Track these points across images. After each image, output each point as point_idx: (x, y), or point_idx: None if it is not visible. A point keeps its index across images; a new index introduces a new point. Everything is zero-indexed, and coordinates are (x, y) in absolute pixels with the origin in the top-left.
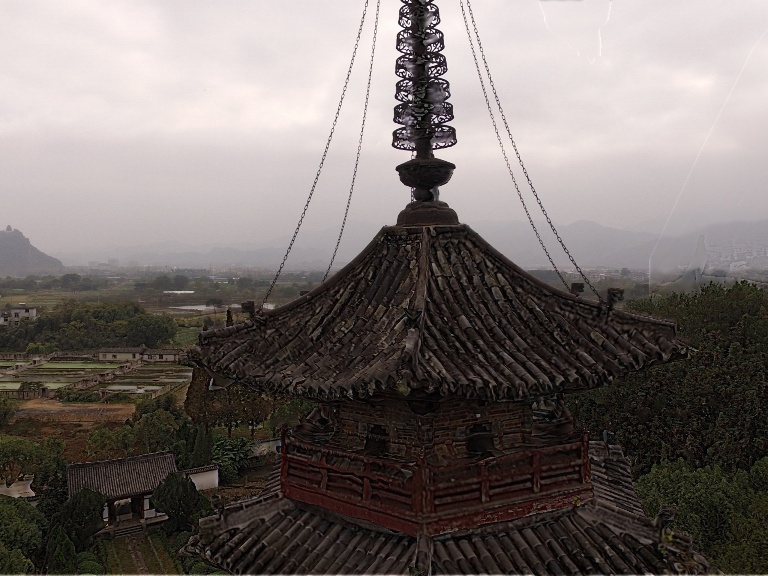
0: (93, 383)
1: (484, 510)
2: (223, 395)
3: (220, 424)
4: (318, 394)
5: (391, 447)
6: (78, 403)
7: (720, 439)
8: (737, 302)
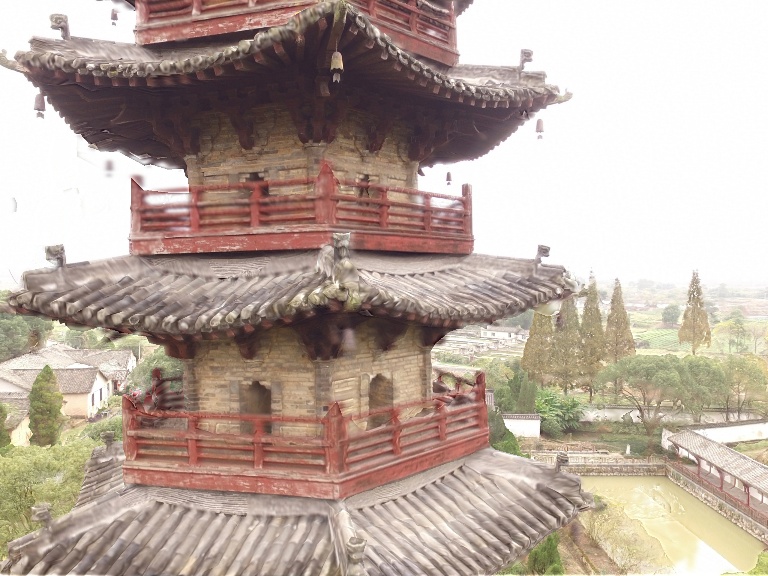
0: (469, 352)
1: (193, 22)
2: (561, 357)
3: (555, 384)
4: None
5: None
6: (451, 364)
7: None
8: None
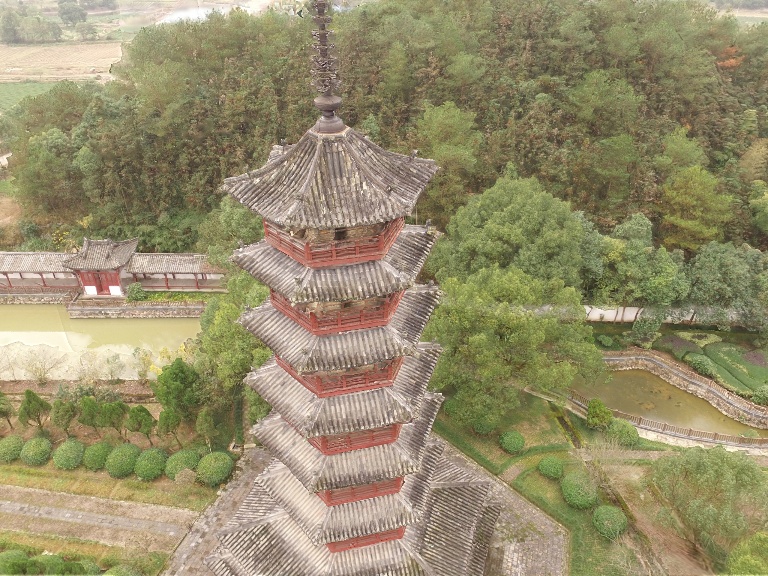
0: None
1: None
2: None
3: None
4: (365, 224)
5: (348, 232)
6: None
7: (260, 146)
8: (241, 30)
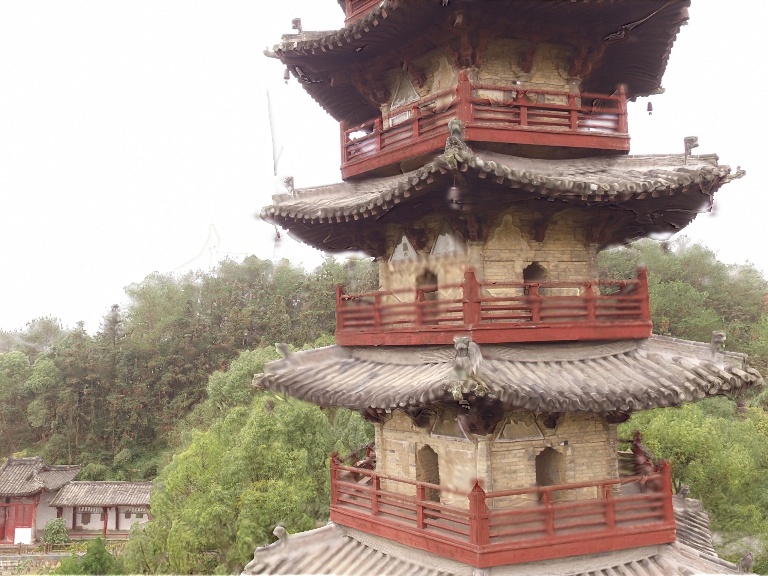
0: None
1: None
2: None
3: None
4: None
5: None
6: None
7: None
8: (254, 266)
